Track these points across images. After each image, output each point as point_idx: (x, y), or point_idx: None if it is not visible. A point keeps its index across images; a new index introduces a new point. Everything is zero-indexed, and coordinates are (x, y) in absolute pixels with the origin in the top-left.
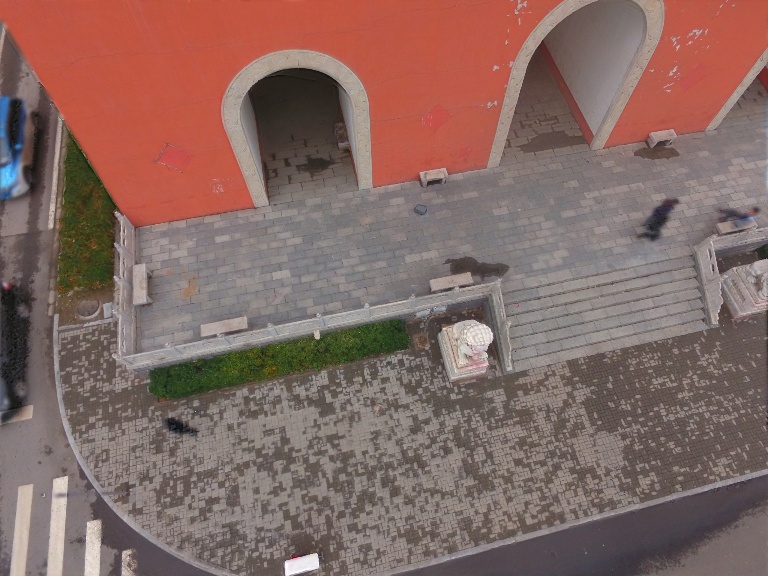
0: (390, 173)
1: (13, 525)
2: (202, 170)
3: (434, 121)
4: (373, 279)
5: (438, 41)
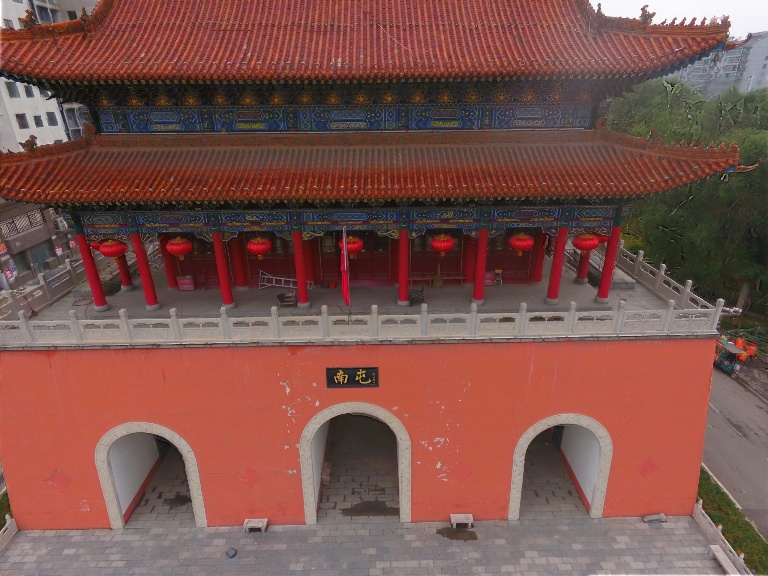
0: (221, 516)
1: None
2: (77, 492)
3: (250, 479)
4: None
5: (239, 426)
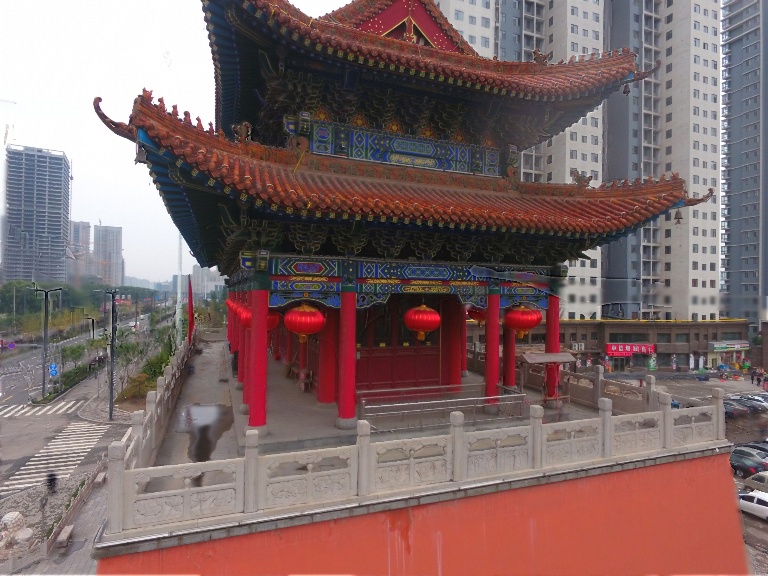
0: None
1: (59, 471)
2: None
3: None
4: None
5: None
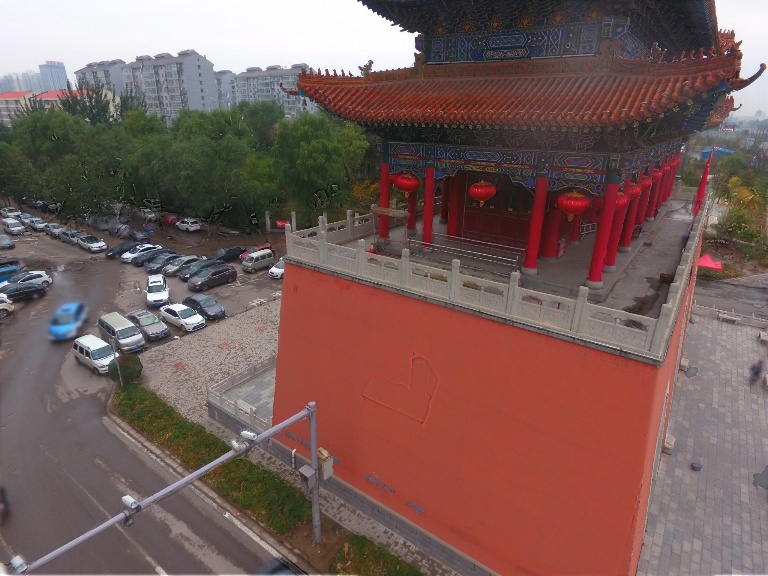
0: None
1: None
2: None
3: None
4: (762, 529)
5: None
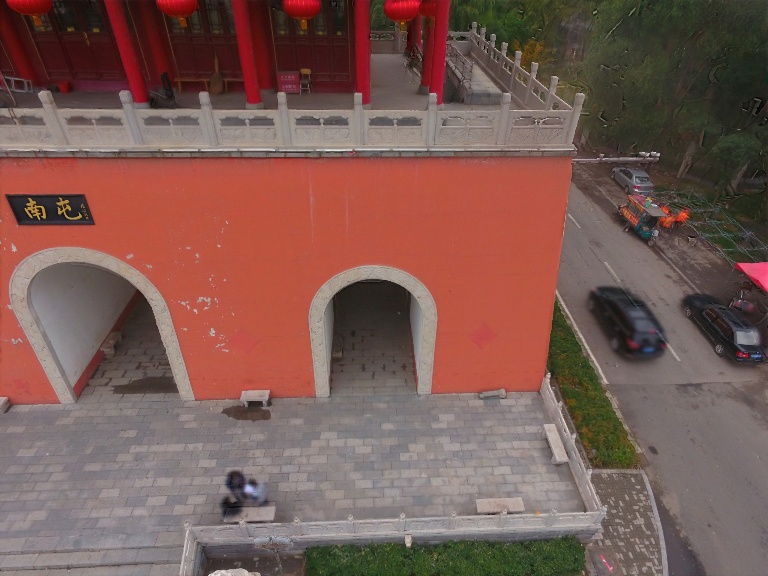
0: None
1: None
2: None
3: None
4: None
5: None
